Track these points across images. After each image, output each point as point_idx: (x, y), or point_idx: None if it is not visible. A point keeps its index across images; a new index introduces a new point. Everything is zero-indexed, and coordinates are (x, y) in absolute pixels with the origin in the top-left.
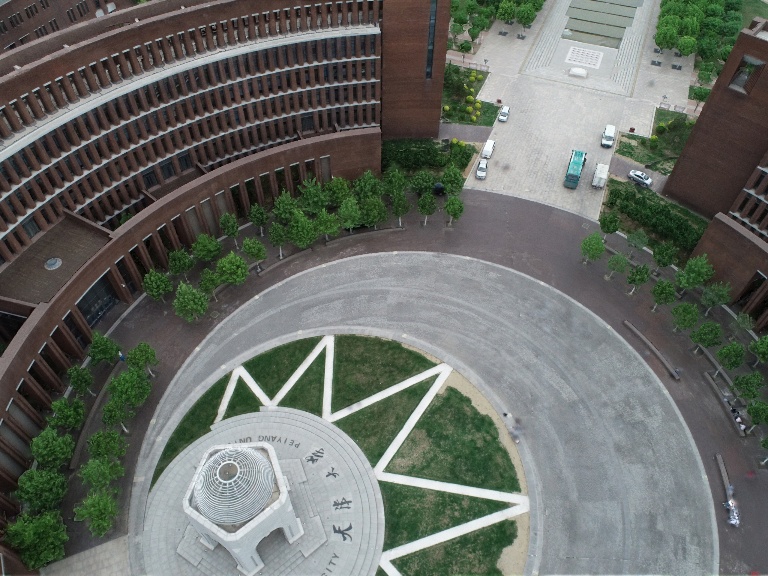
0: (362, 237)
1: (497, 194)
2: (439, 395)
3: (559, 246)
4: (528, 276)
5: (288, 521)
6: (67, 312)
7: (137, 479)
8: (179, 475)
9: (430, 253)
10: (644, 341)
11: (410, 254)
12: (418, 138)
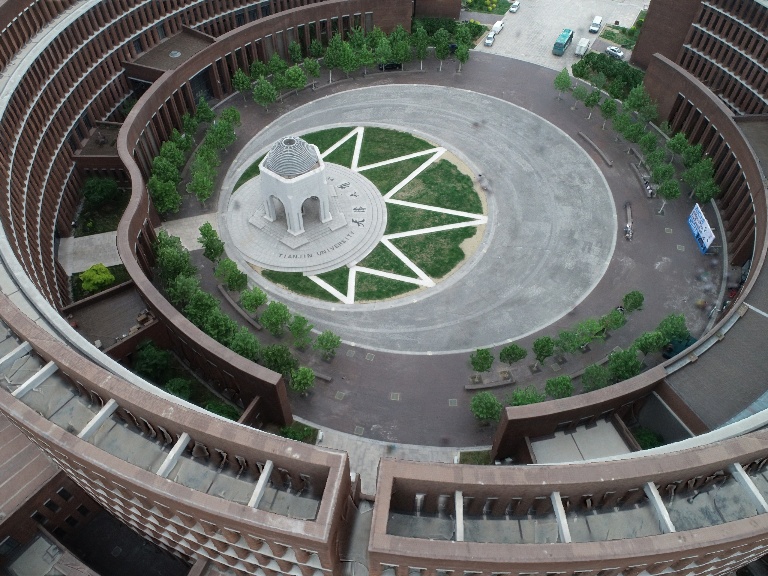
0: (392, 74)
1: (499, 56)
2: (435, 163)
3: (540, 89)
4: (513, 104)
5: (323, 195)
6: (183, 83)
7: (224, 187)
8: (251, 188)
9: (441, 87)
10: (591, 143)
11: (426, 86)
12: (443, 18)
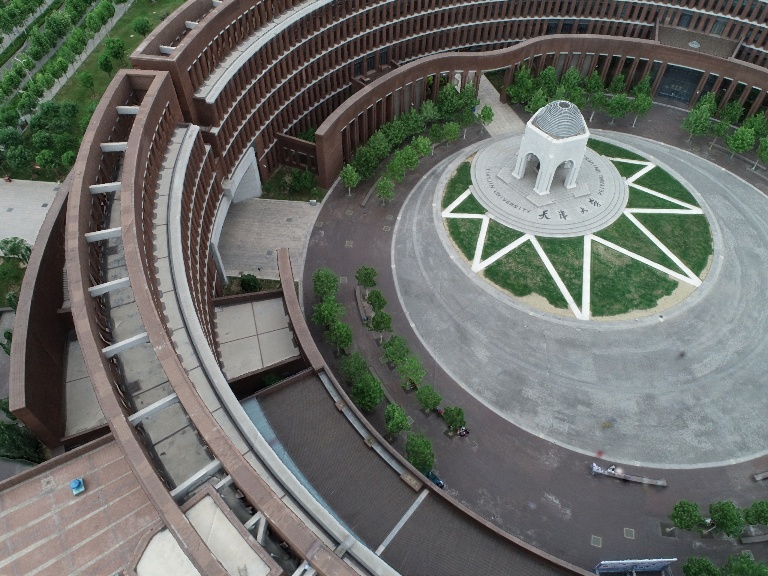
0: None
1: None
2: (667, 275)
3: None
4: None
5: (544, 166)
6: (660, 61)
7: None
8: None
9: None
10: None
11: None
12: None
